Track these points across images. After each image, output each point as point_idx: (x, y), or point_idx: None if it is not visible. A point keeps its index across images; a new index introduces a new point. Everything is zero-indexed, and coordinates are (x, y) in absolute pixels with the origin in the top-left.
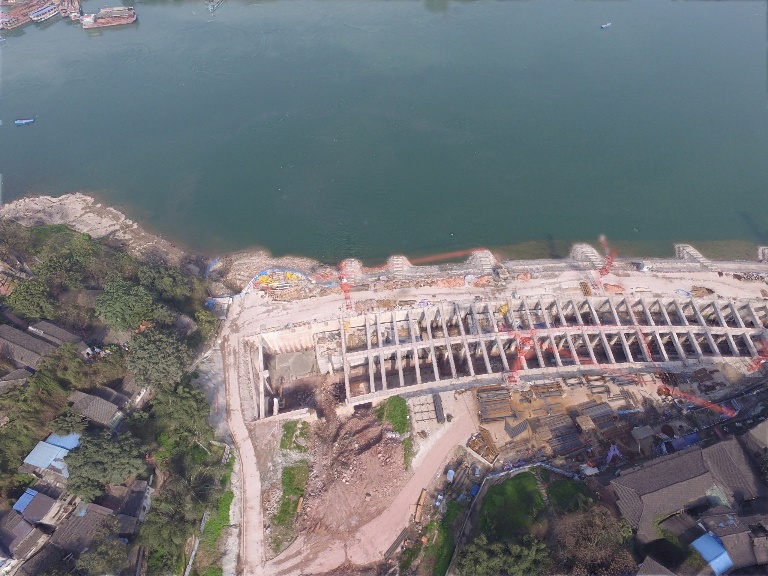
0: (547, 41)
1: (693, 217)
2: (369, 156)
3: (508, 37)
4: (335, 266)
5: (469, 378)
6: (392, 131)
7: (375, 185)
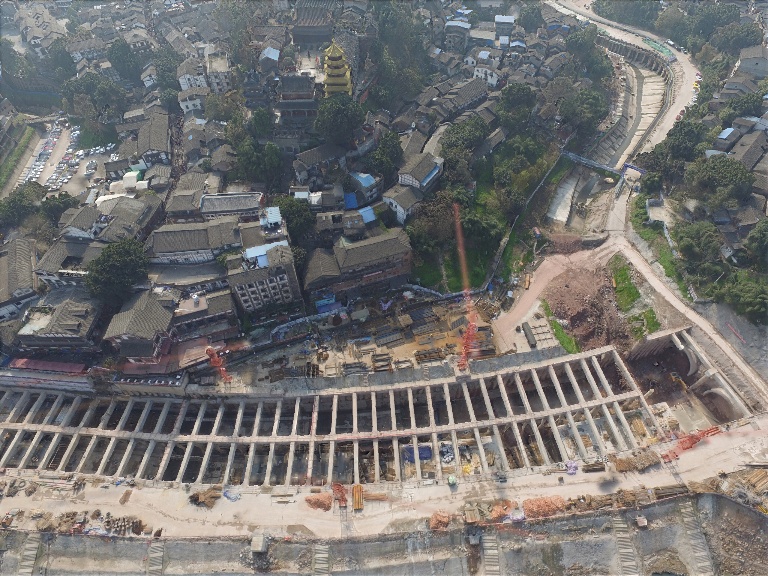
0: None
1: None
2: None
3: None
4: None
5: (503, 372)
6: None
7: None
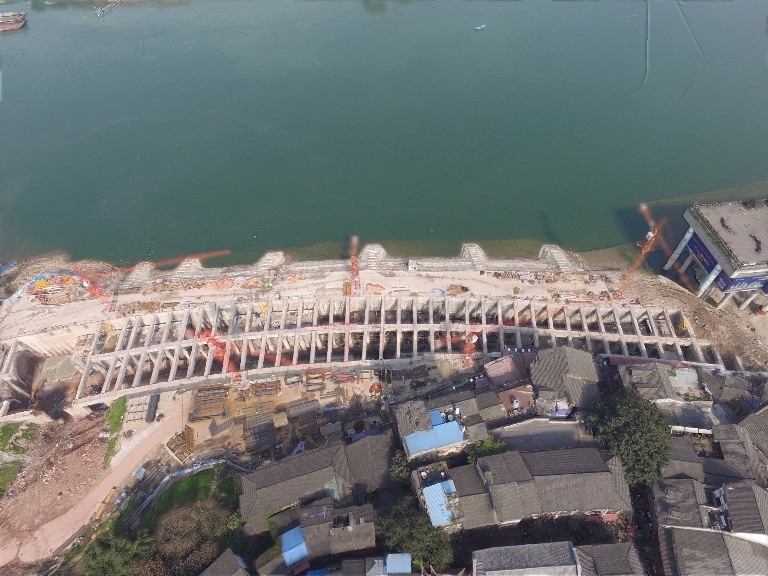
0: (420, 43)
1: (491, 217)
2: (201, 160)
3: (384, 40)
4: (127, 269)
5: (200, 378)
6: (234, 135)
7: (197, 188)
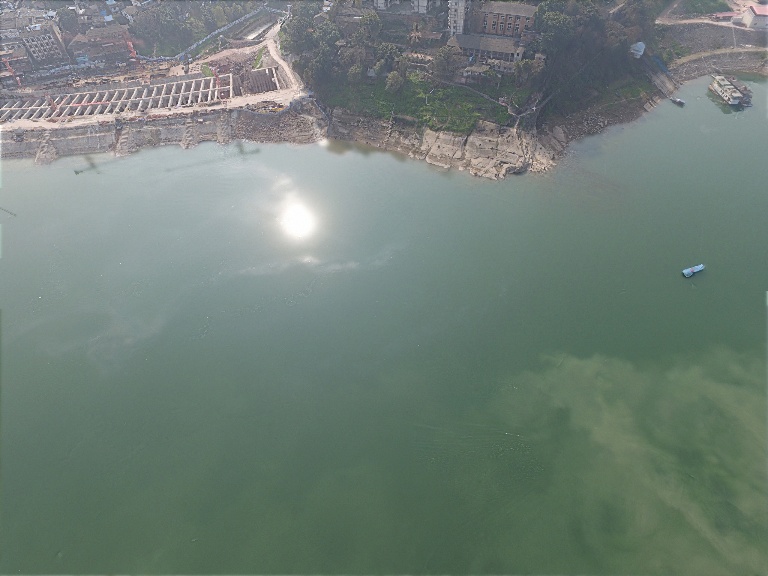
0: None
1: None
2: (187, 236)
3: None
4: (237, 140)
5: (168, 84)
6: (146, 281)
7: (190, 205)
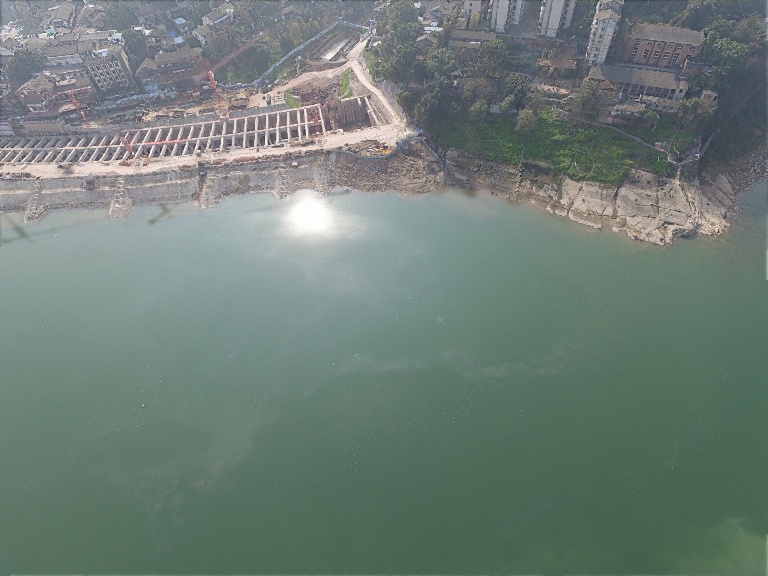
0: None
1: None
2: (305, 320)
3: None
4: (338, 187)
5: (249, 117)
6: (266, 382)
7: (300, 276)
